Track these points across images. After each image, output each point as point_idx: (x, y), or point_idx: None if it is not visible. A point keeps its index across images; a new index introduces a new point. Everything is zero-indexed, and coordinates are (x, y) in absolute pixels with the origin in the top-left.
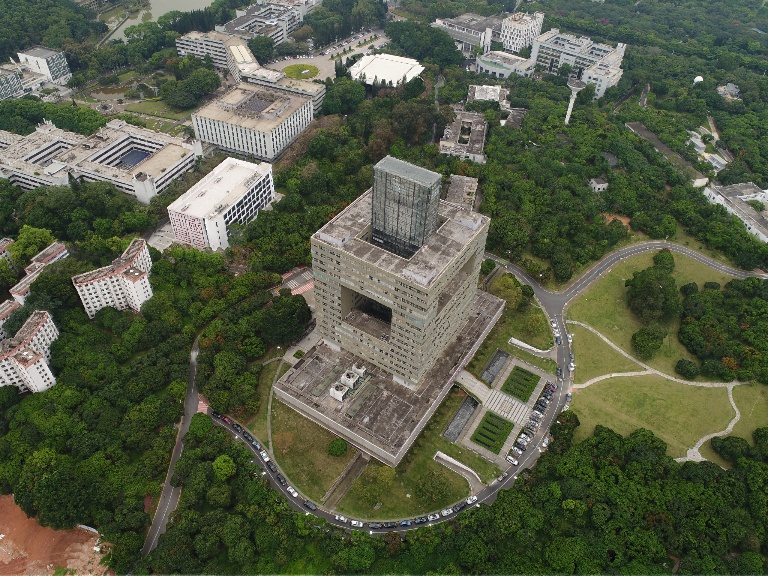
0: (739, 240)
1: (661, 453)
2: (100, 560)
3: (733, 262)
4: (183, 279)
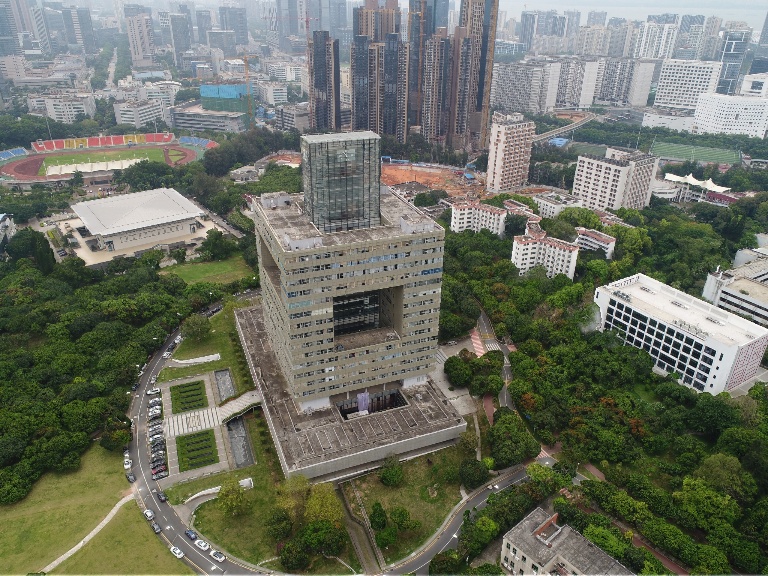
0: None
1: None
2: None
3: None
4: None
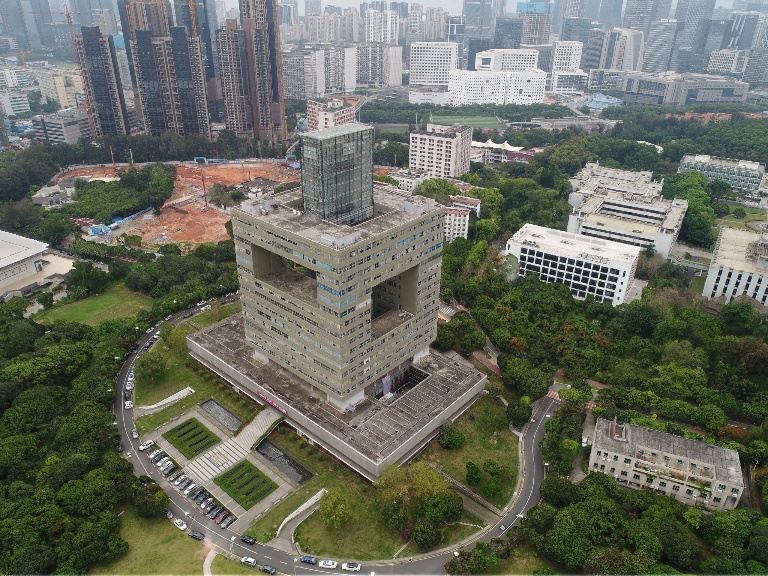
0: None
1: None
2: None
3: None
4: None
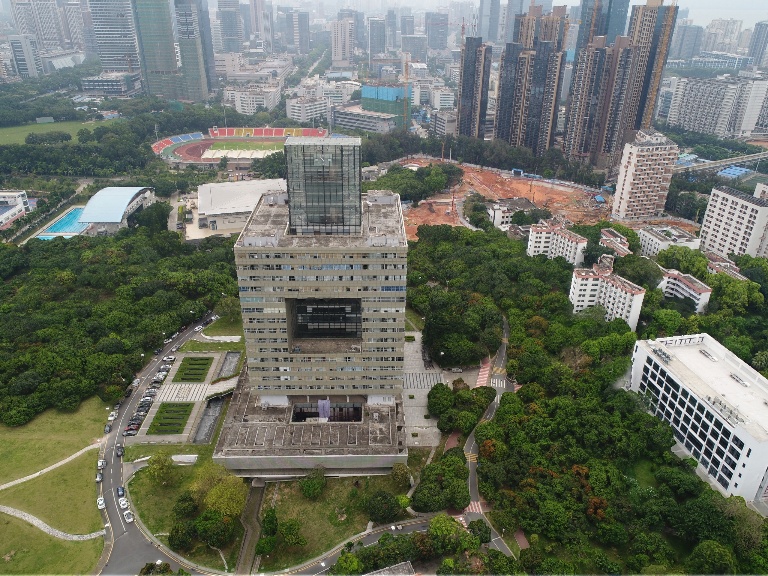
0: None
1: (4, 398)
2: None
3: None
4: None
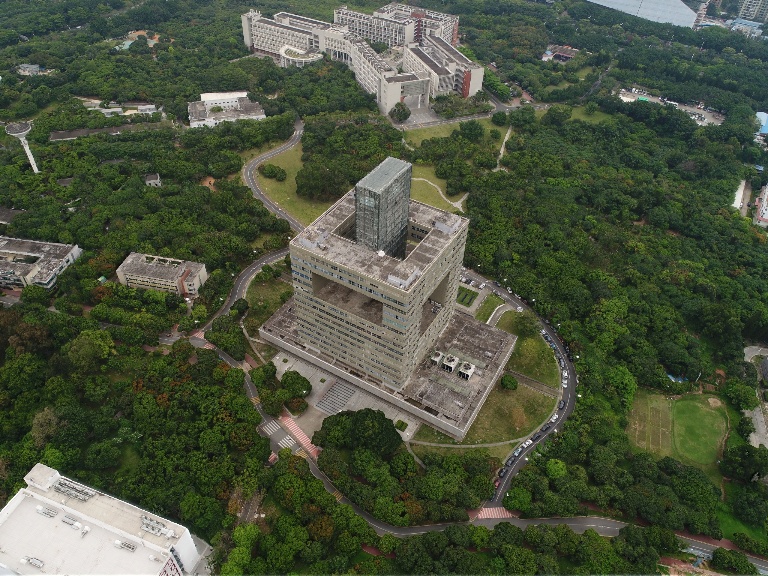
0: (267, 127)
1: None
2: (667, 575)
3: (279, 141)
4: None
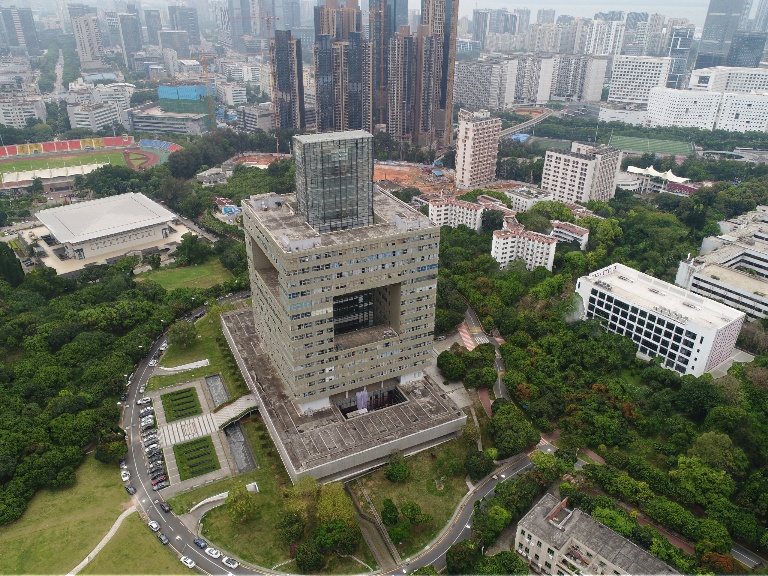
0: None
1: None
2: None
3: None
4: (520, 281)
